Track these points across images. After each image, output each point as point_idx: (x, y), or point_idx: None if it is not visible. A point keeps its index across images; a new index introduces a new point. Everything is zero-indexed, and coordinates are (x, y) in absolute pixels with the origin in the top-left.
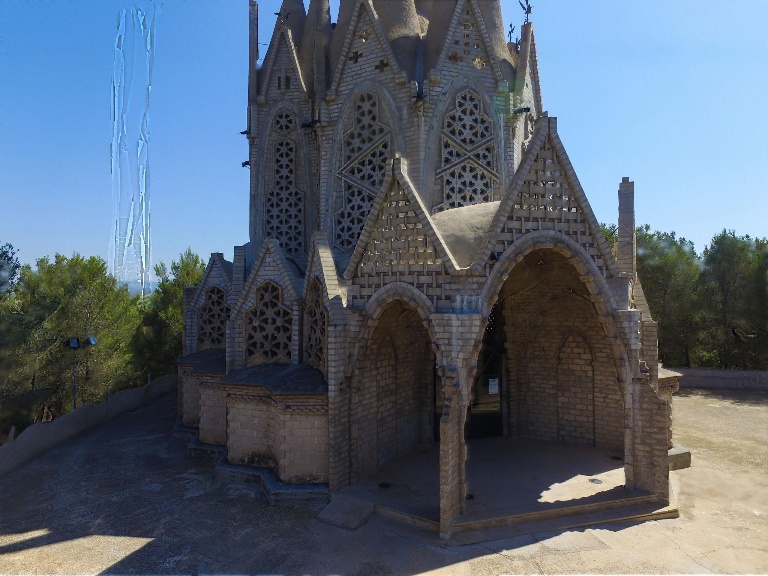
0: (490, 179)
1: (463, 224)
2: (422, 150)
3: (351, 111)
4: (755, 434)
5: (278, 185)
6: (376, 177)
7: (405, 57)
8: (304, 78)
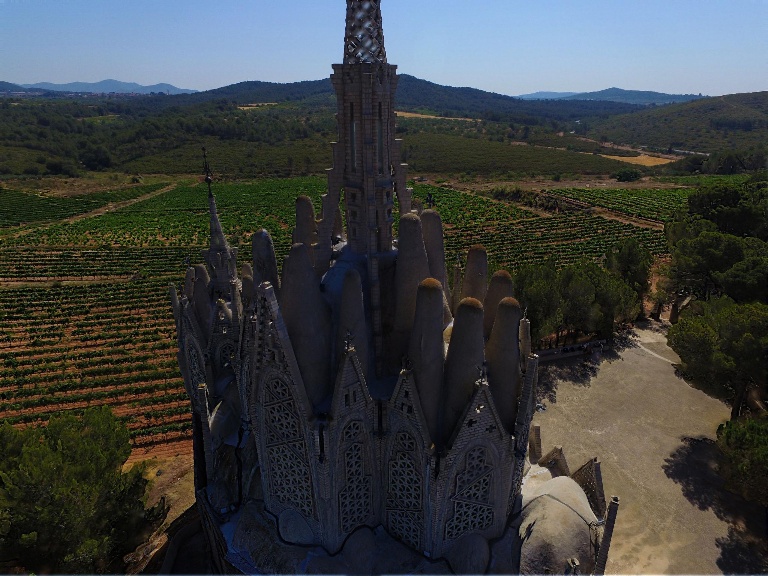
0: None
1: (571, 548)
2: None
3: (464, 458)
4: None
5: (349, 481)
6: (479, 494)
7: None
8: None
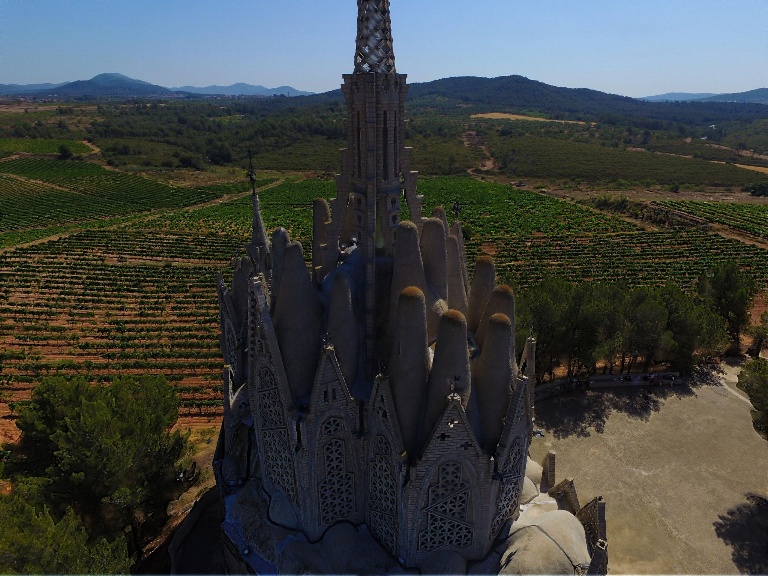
0: (517, 479)
1: None
2: (492, 495)
3: (437, 471)
4: (583, 493)
5: (330, 474)
6: (456, 511)
7: (473, 420)
8: (345, 382)
